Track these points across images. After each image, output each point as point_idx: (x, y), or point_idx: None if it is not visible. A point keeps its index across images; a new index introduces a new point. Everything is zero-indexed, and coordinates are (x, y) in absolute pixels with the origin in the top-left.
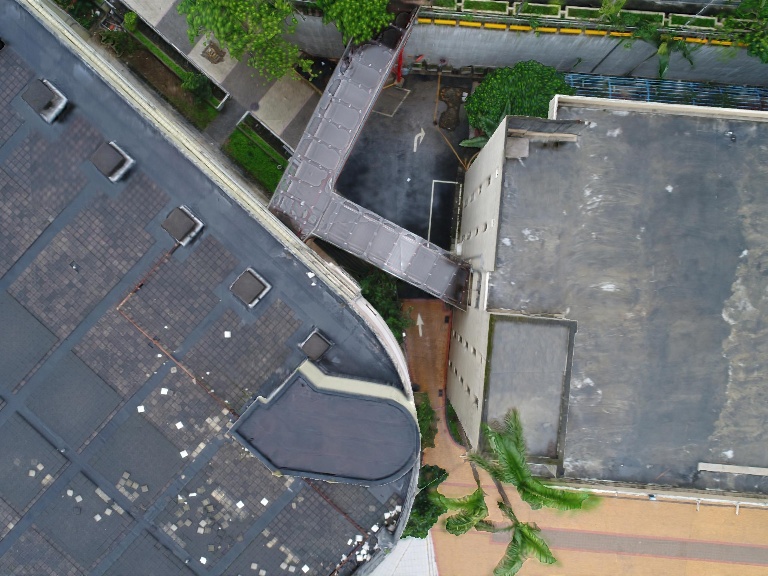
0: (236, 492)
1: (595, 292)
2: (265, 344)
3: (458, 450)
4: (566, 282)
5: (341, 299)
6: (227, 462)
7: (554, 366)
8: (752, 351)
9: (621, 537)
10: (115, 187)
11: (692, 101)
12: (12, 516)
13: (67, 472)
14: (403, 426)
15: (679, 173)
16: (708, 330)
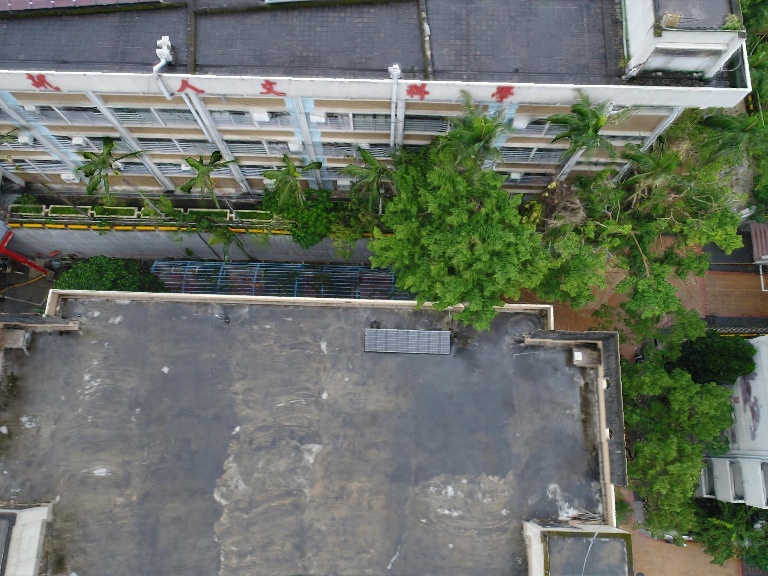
0: None
1: (86, 477)
2: None
3: None
4: (58, 468)
5: None
6: None
7: None
8: (244, 533)
9: None
10: None
11: (295, 281)
12: None
13: None
14: None
15: (175, 355)
16: (200, 512)
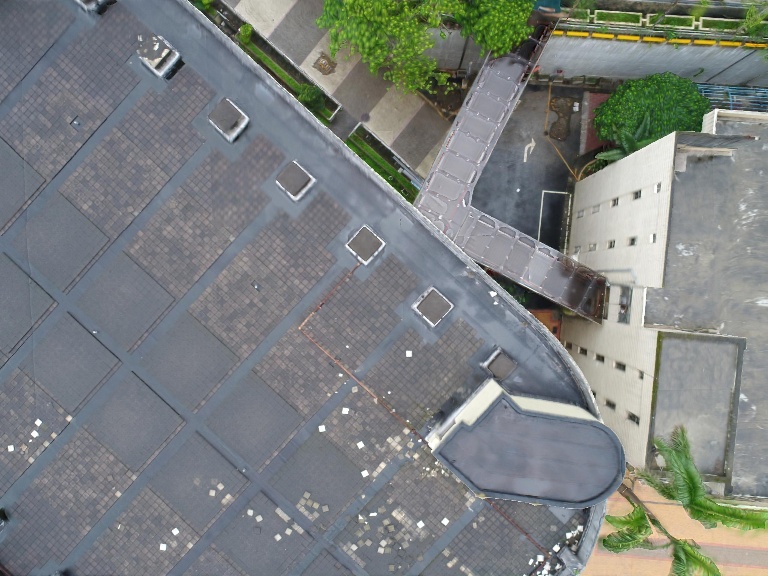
0: (417, 512)
1: (750, 307)
2: (447, 363)
3: None
4: (720, 297)
5: (524, 318)
6: (408, 482)
7: (722, 383)
8: None
9: (728, 548)
10: (296, 206)
11: None
12: (191, 536)
13: (247, 492)
14: (607, 448)
15: None
16: None
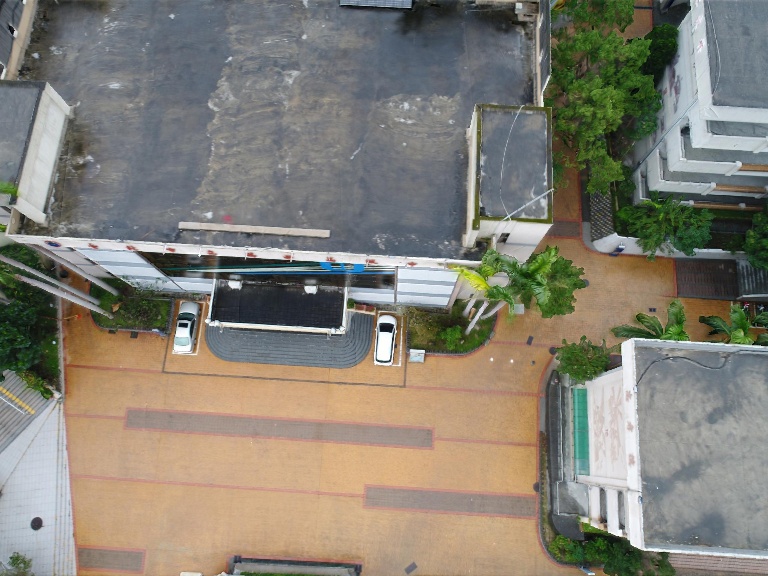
0: None
1: (103, 89)
2: None
3: (99, 333)
4: (80, 83)
5: None
6: None
7: (24, 117)
8: (232, 131)
9: (256, 419)
10: None
11: None
12: None
13: None
14: None
15: (180, 6)
16: (196, 116)
